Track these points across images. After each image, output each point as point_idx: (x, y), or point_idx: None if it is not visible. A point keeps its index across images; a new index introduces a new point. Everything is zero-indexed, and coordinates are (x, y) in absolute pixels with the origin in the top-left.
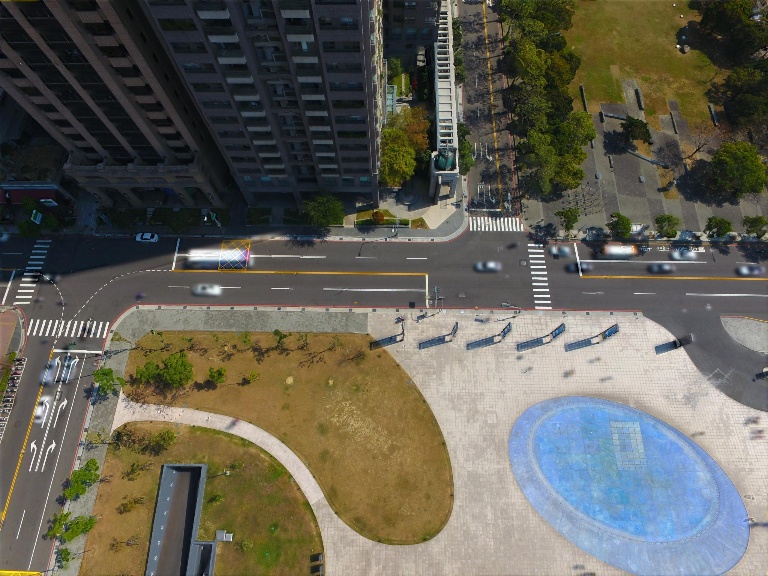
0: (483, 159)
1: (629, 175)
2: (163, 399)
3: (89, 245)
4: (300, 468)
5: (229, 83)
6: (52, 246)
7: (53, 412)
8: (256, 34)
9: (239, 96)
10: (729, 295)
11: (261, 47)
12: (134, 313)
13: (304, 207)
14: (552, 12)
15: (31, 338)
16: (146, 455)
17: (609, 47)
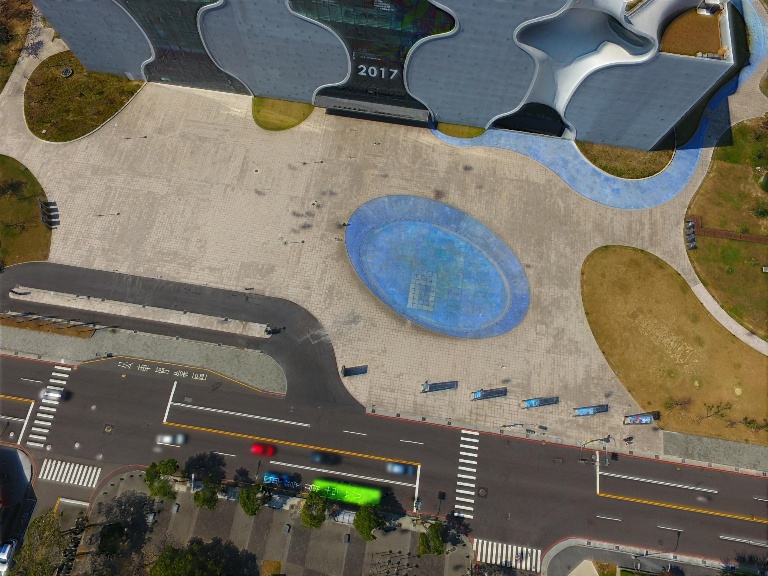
0: None
1: None
2: None
3: None
4: (715, 312)
5: None
6: None
7: None
8: None
9: None
10: (264, 418)
11: None
12: None
13: None
14: None
15: None
16: None
17: None
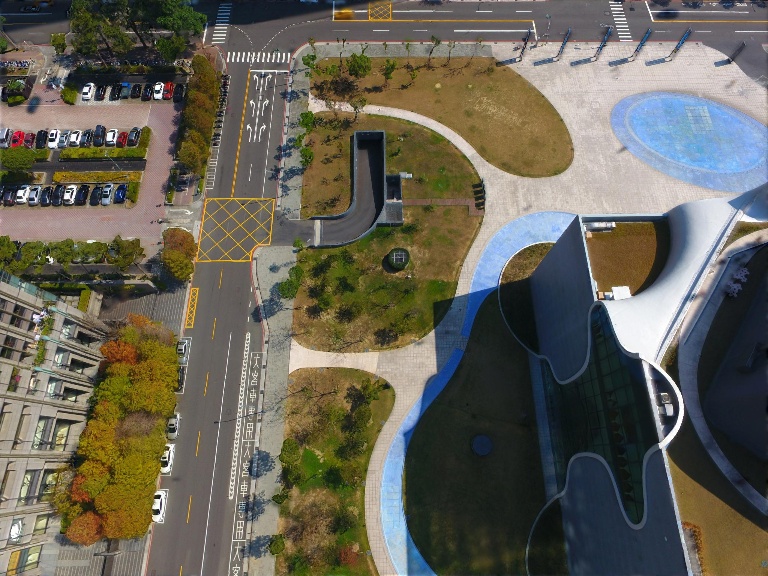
0: None
1: None
2: (343, 98)
3: (263, 6)
4: (455, 136)
5: None
6: (233, 7)
7: (259, 107)
8: None
9: None
10: (767, 32)
11: None
12: (309, 47)
13: None
14: None
15: (231, 64)
16: (337, 130)
17: None
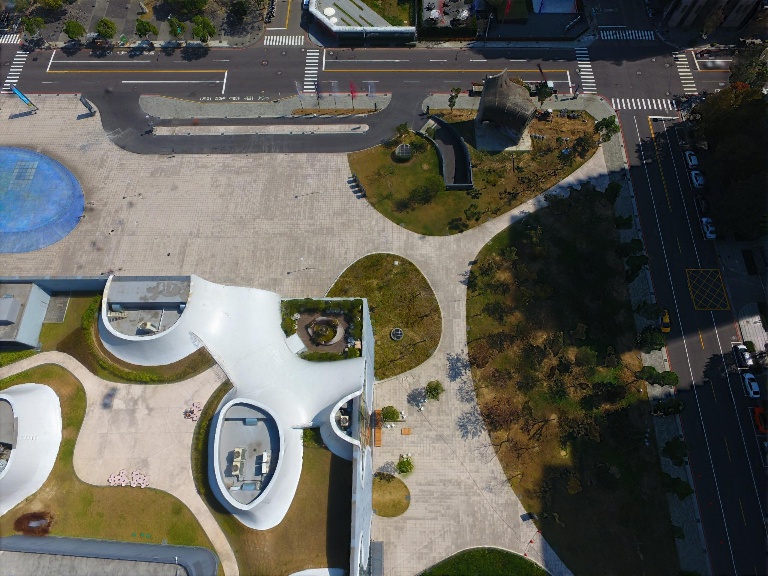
0: None
1: (120, 4)
2: None
3: None
4: None
5: None
6: None
7: None
8: None
9: None
10: (155, 82)
11: None
12: None
13: None
14: None
15: None
16: None
17: None
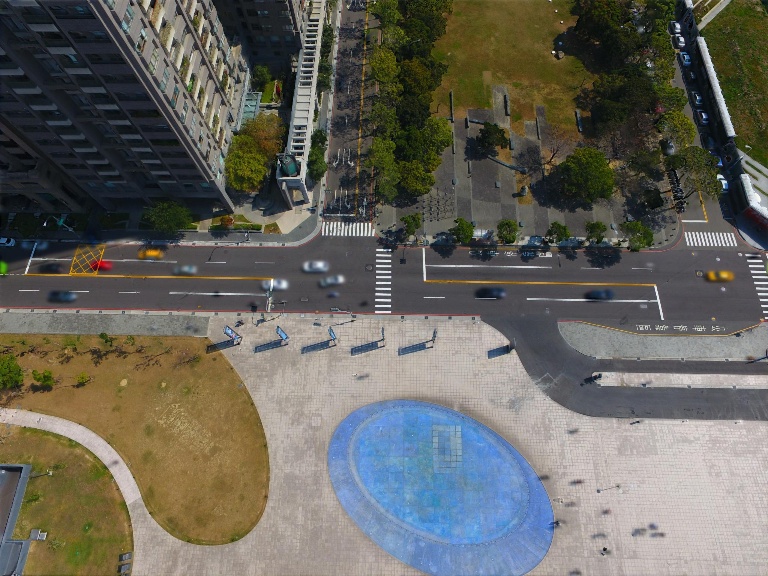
0: (344, 165)
1: (486, 180)
2: None
3: None
4: (122, 469)
5: (18, 93)
6: None
7: None
8: (21, 47)
9: (35, 106)
10: (569, 300)
11: (44, 59)
12: None
13: (146, 212)
14: (423, 19)
15: None
16: None
17: (485, 53)
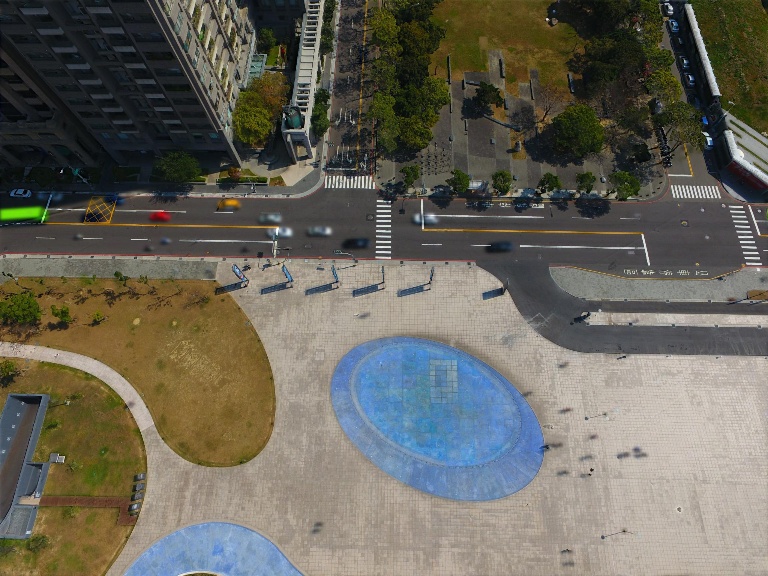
0: (346, 123)
1: (482, 137)
2: (17, 338)
3: None
4: (136, 399)
5: (42, 34)
6: None
7: None
8: None
9: (57, 48)
10: (561, 247)
11: (66, 0)
12: (1, 261)
13: (158, 162)
14: None
15: None
16: None
17: (481, 20)
